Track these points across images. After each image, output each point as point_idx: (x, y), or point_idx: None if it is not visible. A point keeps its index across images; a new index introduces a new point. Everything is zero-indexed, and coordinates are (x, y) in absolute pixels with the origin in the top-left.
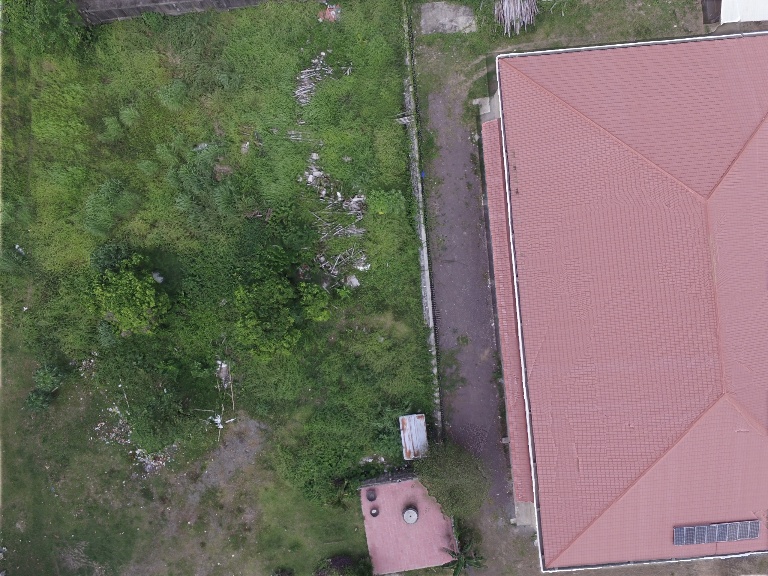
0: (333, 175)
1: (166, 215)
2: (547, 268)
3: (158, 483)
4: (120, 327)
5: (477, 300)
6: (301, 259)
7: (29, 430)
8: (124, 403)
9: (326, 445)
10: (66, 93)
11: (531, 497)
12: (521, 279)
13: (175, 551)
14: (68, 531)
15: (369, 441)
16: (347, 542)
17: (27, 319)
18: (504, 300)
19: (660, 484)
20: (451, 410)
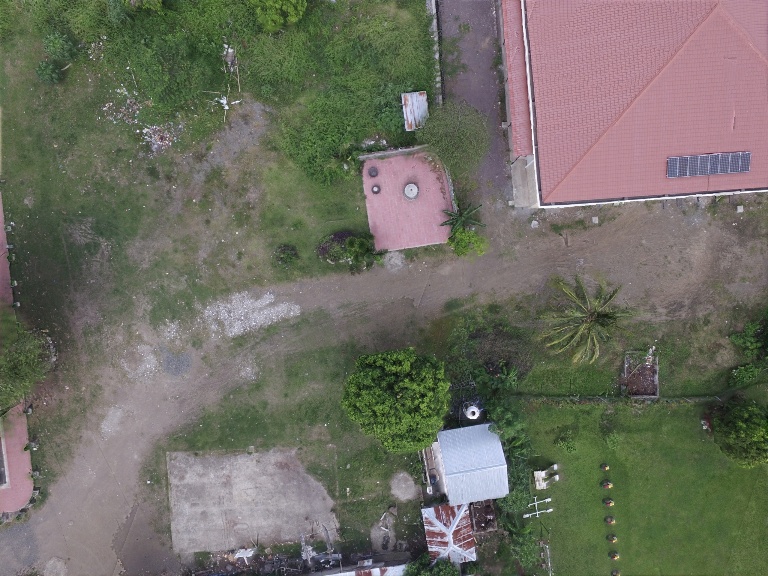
0: None
1: None
2: None
3: (164, 162)
4: None
5: None
6: None
7: (38, 109)
8: (132, 84)
9: (330, 122)
10: None
11: (529, 149)
12: None
13: (180, 228)
14: (75, 207)
15: (372, 118)
16: (349, 221)
17: None
18: None
19: (655, 108)
20: (452, 94)
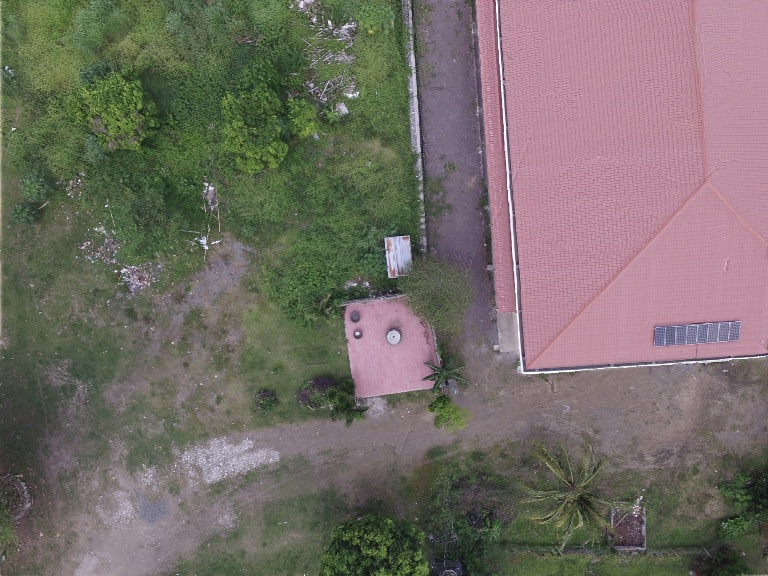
0: (324, 1)
1: (156, 37)
2: (531, 23)
3: (142, 303)
4: (107, 138)
5: (465, 127)
6: (290, 84)
7: (15, 248)
8: (110, 223)
9: (311, 265)
10: None
11: (514, 306)
12: (508, 82)
13: (158, 371)
14: (51, 349)
15: (354, 262)
16: (330, 365)
17: (15, 136)
18: (491, 111)
19: (641, 279)
20: (437, 236)
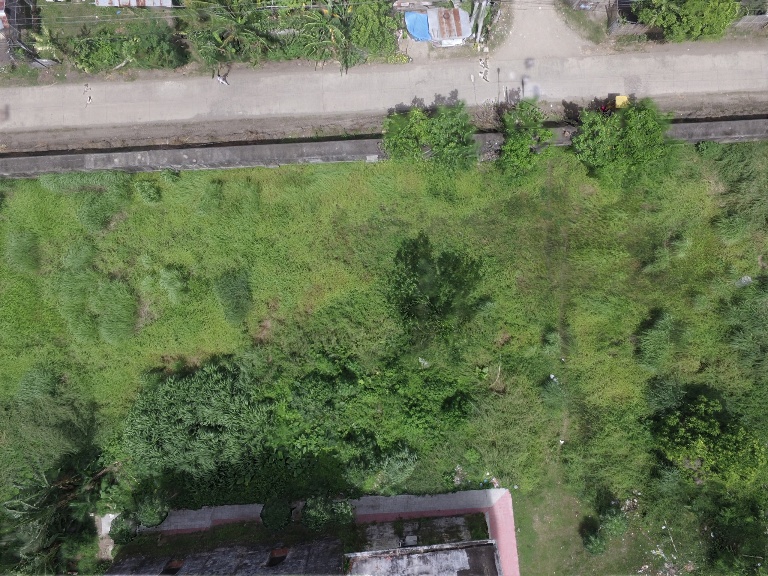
0: None
1: (716, 352)
2: None
3: None
4: (696, 475)
5: None
6: None
7: (569, 570)
8: (670, 546)
9: None
10: (609, 219)
11: None
12: None
13: None
14: None
15: None
16: None
17: (576, 456)
18: None
19: None
20: None
